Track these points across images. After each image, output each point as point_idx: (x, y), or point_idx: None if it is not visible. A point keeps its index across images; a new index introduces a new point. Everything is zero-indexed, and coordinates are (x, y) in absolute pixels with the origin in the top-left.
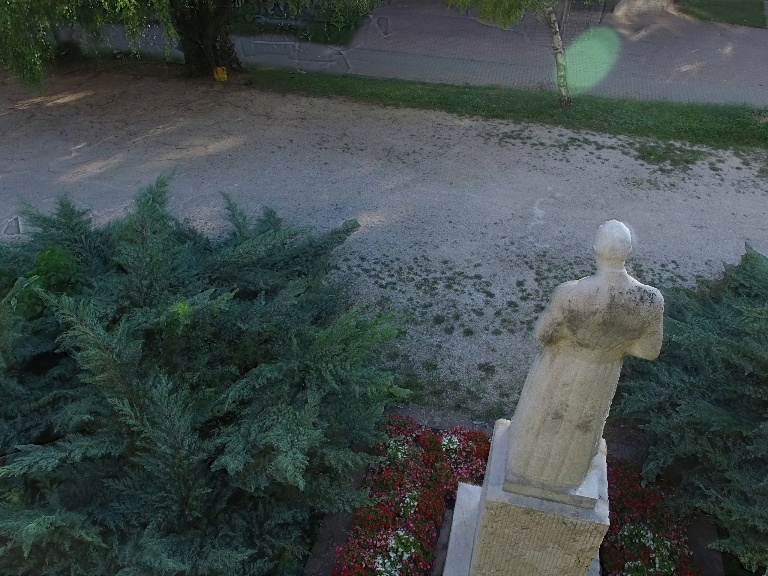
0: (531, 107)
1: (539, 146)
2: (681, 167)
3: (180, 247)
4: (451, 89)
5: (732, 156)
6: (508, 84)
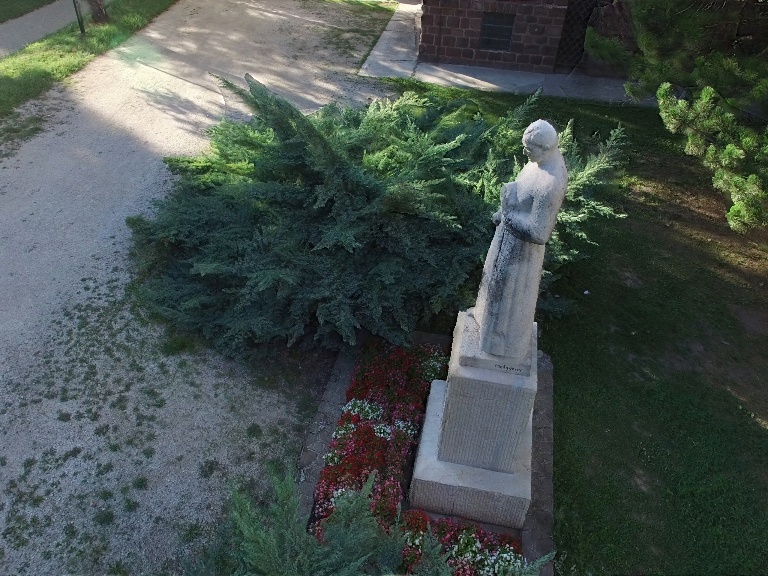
0: None
1: None
2: None
3: None
4: None
5: None
6: None
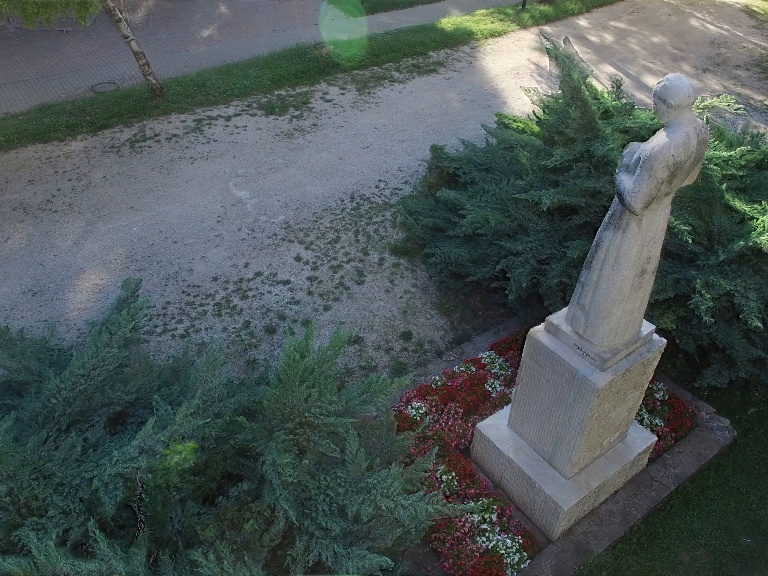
0: (129, 106)
1: (174, 138)
2: (305, 109)
3: (12, 414)
4: (4, 123)
5: (329, 87)
6: (54, 99)
